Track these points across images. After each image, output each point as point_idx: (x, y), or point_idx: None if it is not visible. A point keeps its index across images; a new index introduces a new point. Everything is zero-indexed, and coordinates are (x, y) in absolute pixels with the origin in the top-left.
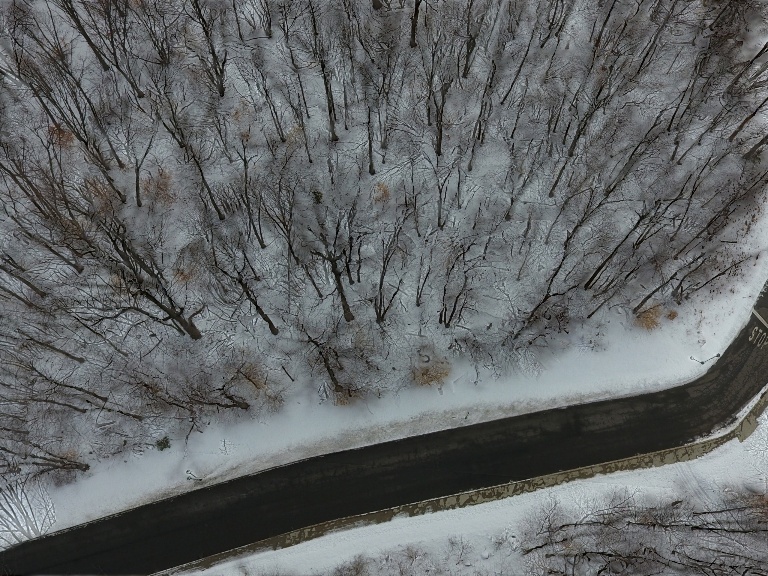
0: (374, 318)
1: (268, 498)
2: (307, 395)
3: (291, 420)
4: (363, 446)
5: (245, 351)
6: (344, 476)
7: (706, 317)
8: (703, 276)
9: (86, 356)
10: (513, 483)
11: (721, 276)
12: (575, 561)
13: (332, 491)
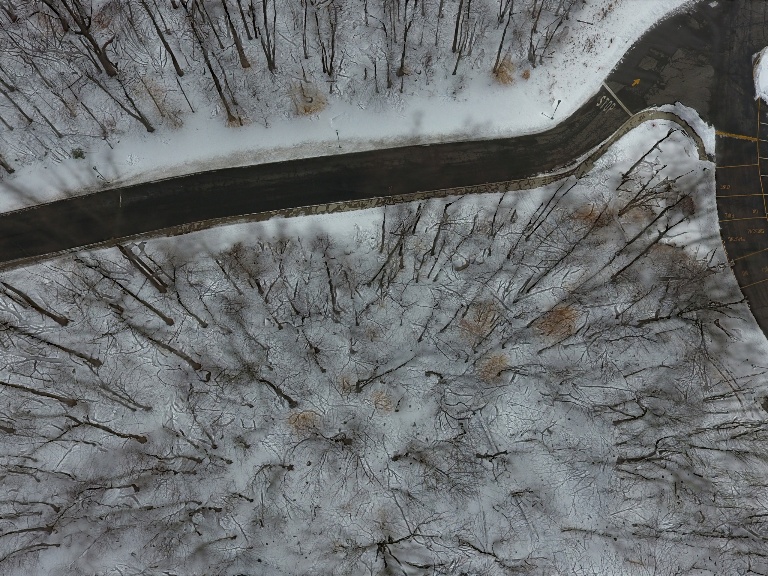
0: (266, 63)
1: (166, 200)
2: (205, 123)
3: (189, 142)
4: (250, 165)
5: (153, 85)
6: (232, 187)
7: (558, 82)
8: (557, 45)
9: (16, 86)
10: (376, 198)
11: (575, 49)
12: (423, 259)
13: (221, 197)
